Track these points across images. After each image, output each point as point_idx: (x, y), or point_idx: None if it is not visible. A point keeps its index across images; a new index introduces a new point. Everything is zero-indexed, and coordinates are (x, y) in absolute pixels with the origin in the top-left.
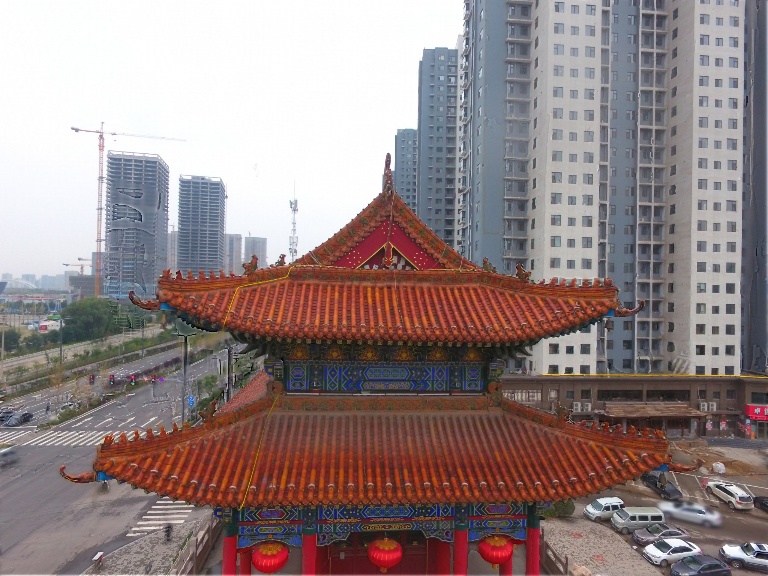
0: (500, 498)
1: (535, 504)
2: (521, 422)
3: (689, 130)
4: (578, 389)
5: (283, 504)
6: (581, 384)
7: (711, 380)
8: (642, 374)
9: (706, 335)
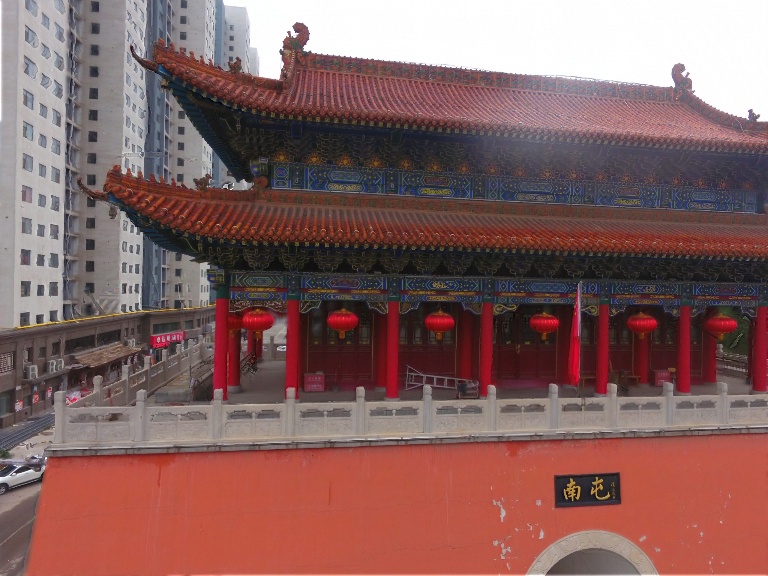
0: None
1: None
2: None
3: (120, 59)
4: (50, 343)
5: None
6: (53, 335)
7: (134, 317)
8: (96, 316)
9: (127, 274)
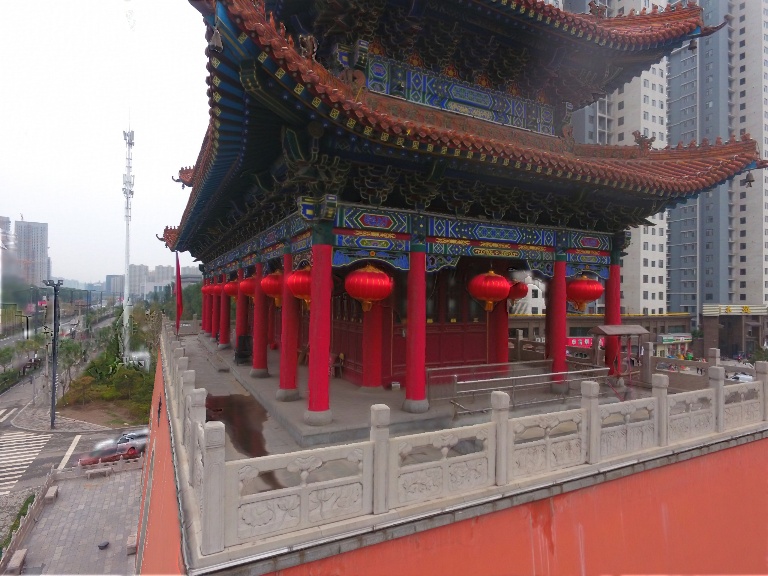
0: (644, 179)
1: (623, 234)
2: (600, 160)
3: None
4: None
5: (454, 143)
6: None
7: (543, 318)
8: None
9: None
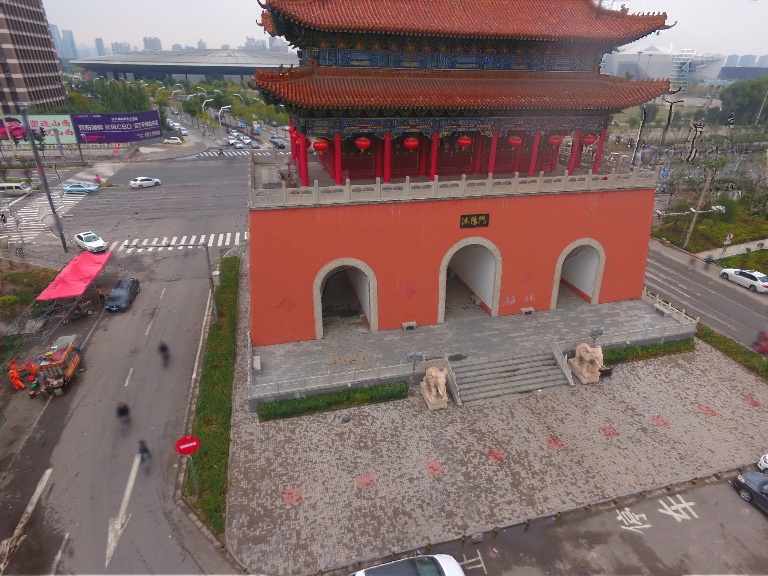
0: None
1: None
2: None
3: None
4: None
5: None
6: None
7: None
8: None
9: None
